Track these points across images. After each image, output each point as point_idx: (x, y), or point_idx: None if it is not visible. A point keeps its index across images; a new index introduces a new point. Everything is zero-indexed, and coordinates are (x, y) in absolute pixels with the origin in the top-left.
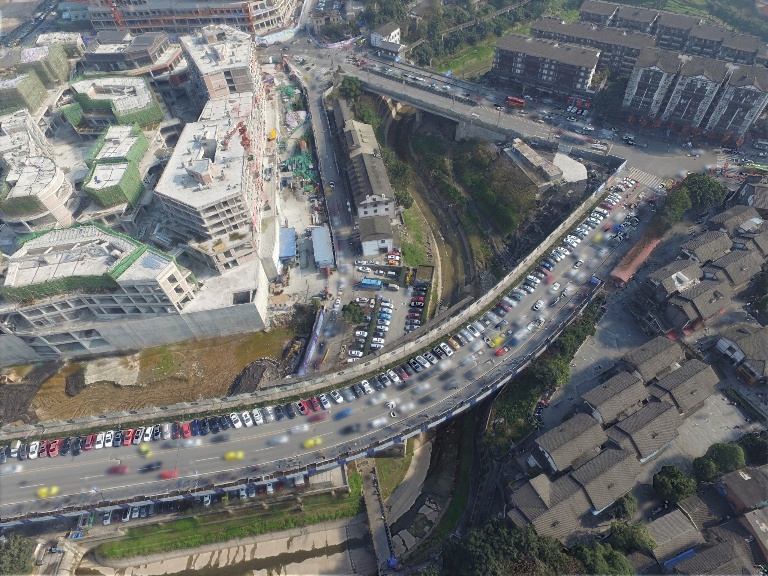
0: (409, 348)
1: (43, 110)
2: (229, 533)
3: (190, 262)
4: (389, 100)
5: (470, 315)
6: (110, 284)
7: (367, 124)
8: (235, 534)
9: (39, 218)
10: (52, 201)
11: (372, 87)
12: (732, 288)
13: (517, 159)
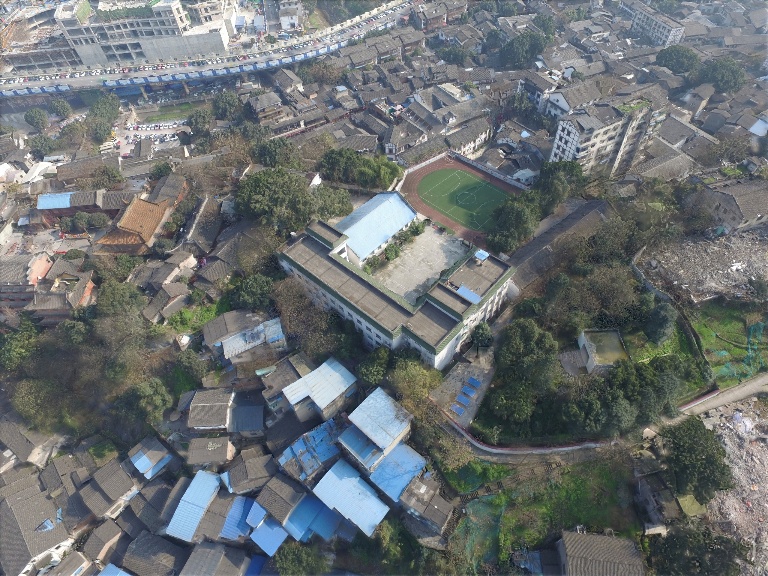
0: (294, 43)
1: None
2: None
3: None
4: None
5: (327, 34)
6: (148, 13)
7: None
8: None
9: None
10: None
11: None
12: (450, 14)
13: None
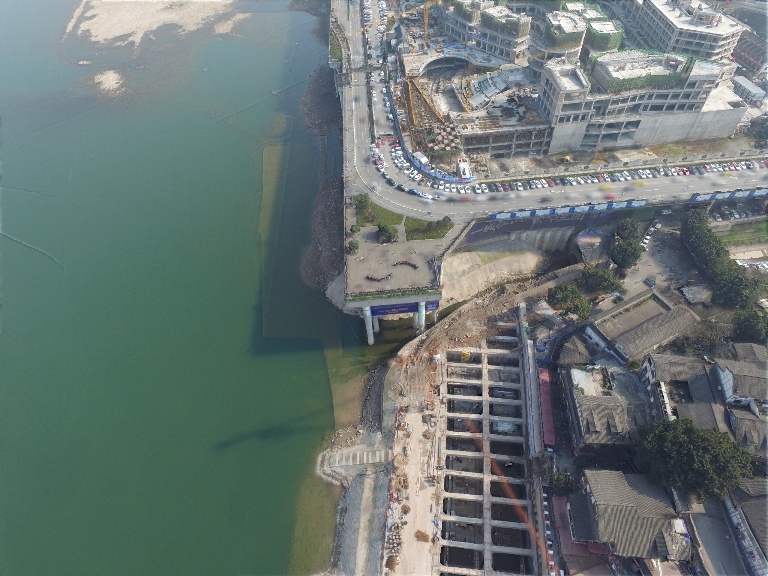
0: None
1: None
2: None
3: None
4: None
5: None
6: (674, 82)
7: (728, 15)
8: None
9: (572, 52)
10: None
11: None
12: None
13: None
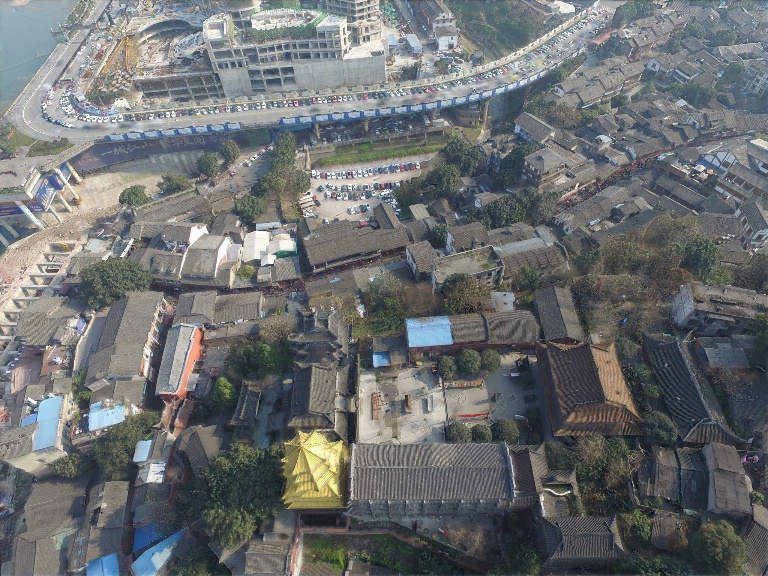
0: (479, 71)
1: None
2: (388, 154)
3: None
4: None
5: (511, 60)
6: (309, 33)
7: None
8: (391, 154)
9: (247, 11)
10: (256, 0)
11: None
12: (656, 40)
13: (530, 4)
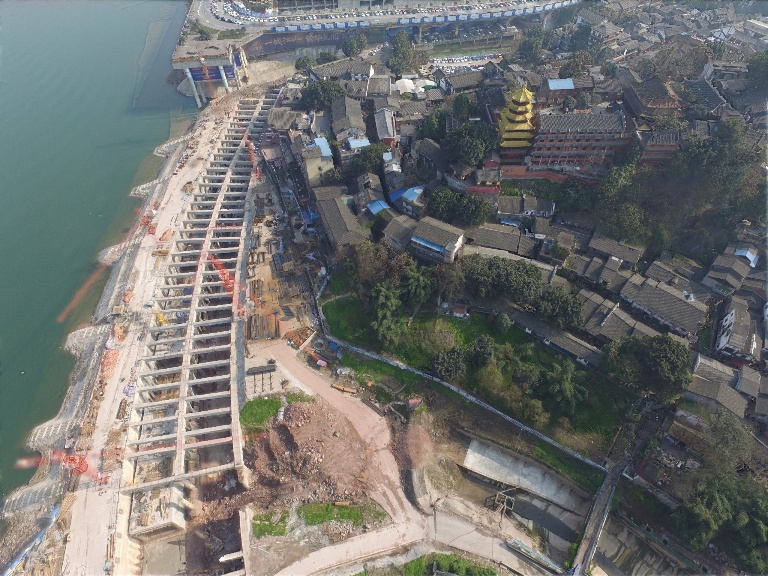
0: None
1: None
2: (473, 53)
3: None
4: None
5: None
6: None
7: None
8: (475, 53)
9: None
10: None
11: None
12: None
13: None
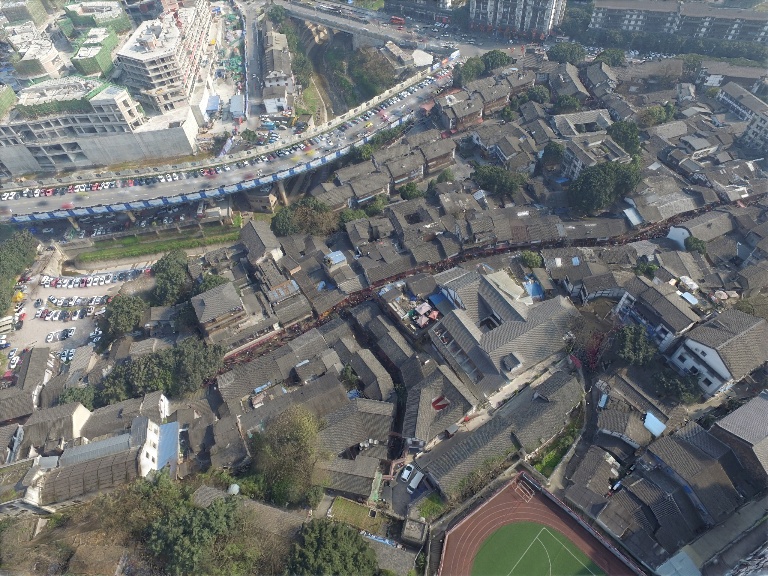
0: (278, 146)
1: (45, 26)
2: (157, 248)
3: (143, 109)
4: (313, 29)
5: (323, 131)
6: (86, 106)
7: (282, 34)
8: (161, 248)
9: (41, 78)
10: (49, 66)
11: (294, 13)
12: (487, 106)
13: (387, 54)
